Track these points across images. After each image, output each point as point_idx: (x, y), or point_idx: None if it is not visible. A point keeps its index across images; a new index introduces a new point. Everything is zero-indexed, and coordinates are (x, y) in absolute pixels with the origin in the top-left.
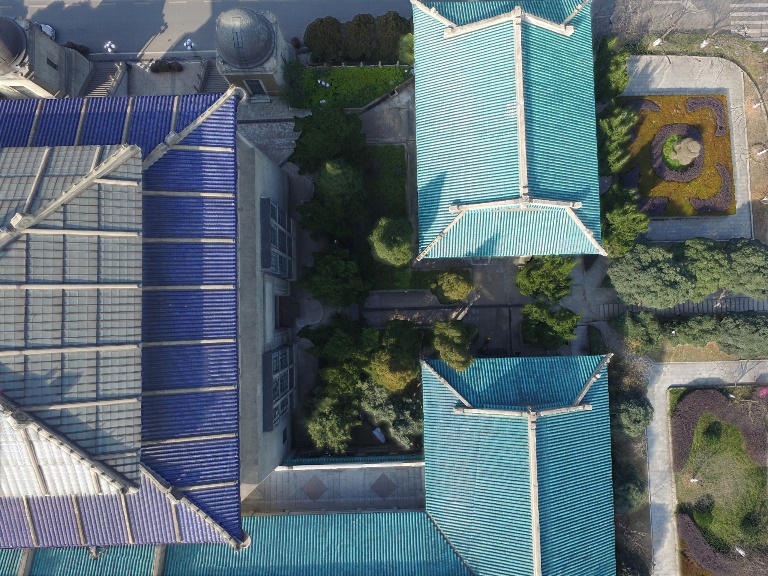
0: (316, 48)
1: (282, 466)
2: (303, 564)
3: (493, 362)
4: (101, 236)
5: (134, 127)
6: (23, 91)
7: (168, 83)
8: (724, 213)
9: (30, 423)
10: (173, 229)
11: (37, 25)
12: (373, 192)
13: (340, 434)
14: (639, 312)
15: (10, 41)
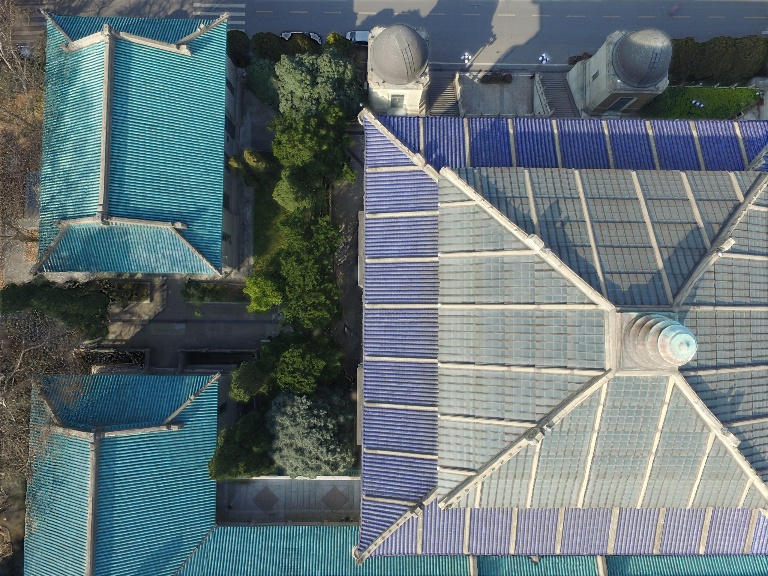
0: None
1: None
2: (735, 574)
3: None
4: (750, 260)
5: (705, 151)
6: (394, 99)
7: (497, 94)
8: None
9: None
10: None
11: None
12: None
13: None
14: None
15: (423, 52)
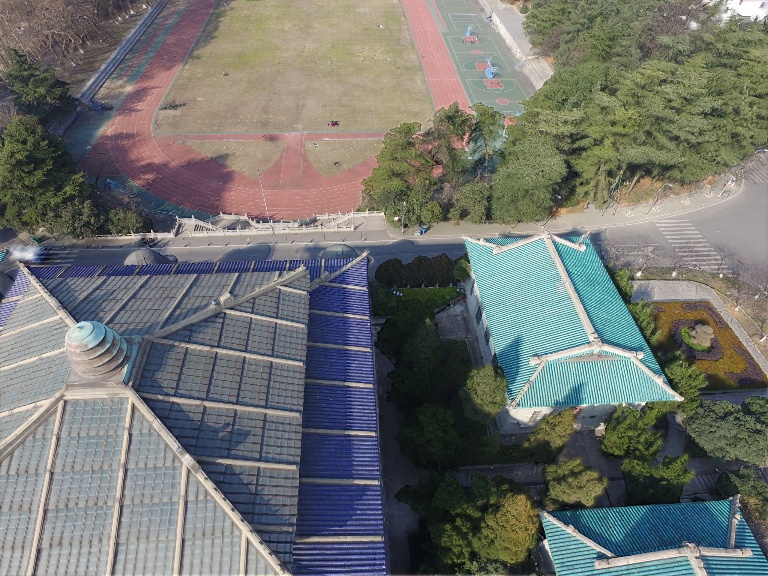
0: (386, 278)
1: None
2: None
3: (617, 511)
4: (278, 323)
5: None
6: None
7: None
8: (762, 384)
9: (199, 469)
10: (322, 337)
11: None
12: (445, 375)
13: None
14: (738, 469)
15: None
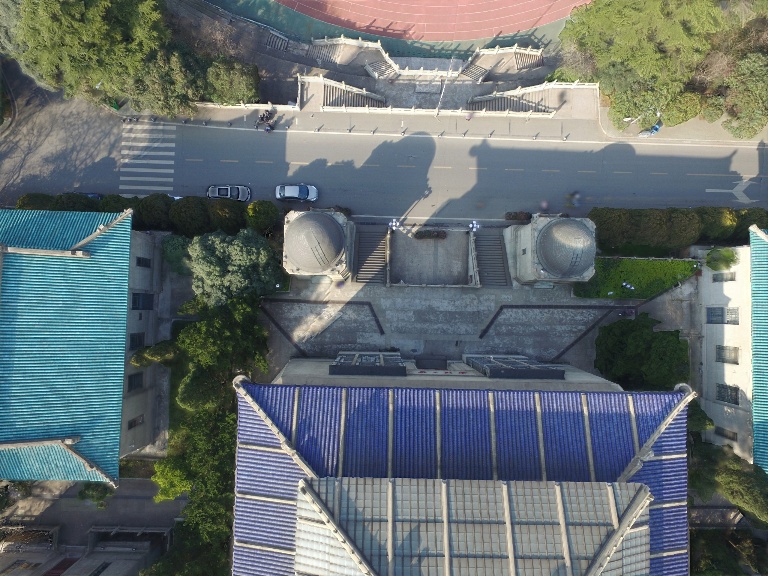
0: (603, 237)
1: None
2: None
3: None
4: None
5: (595, 432)
6: None
7: (431, 250)
8: None
9: None
10: None
11: (304, 187)
12: None
13: None
14: None
15: (337, 244)
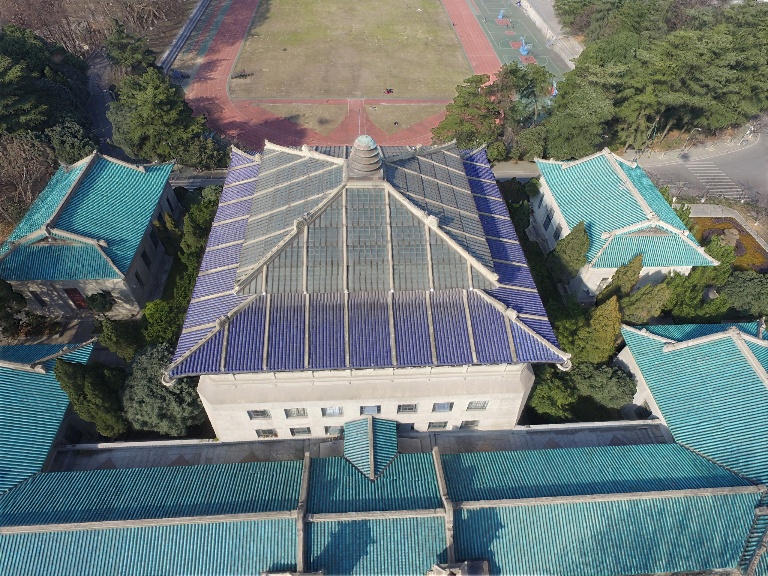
0: None
1: (520, 425)
2: (583, 483)
3: (675, 326)
4: (449, 170)
5: None
6: None
7: None
8: None
9: None
10: None
11: None
12: None
13: (565, 396)
14: None
15: None
